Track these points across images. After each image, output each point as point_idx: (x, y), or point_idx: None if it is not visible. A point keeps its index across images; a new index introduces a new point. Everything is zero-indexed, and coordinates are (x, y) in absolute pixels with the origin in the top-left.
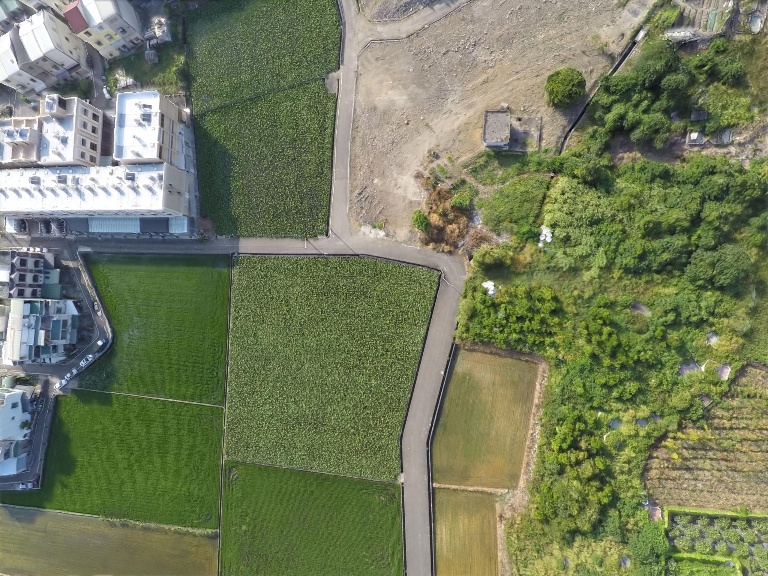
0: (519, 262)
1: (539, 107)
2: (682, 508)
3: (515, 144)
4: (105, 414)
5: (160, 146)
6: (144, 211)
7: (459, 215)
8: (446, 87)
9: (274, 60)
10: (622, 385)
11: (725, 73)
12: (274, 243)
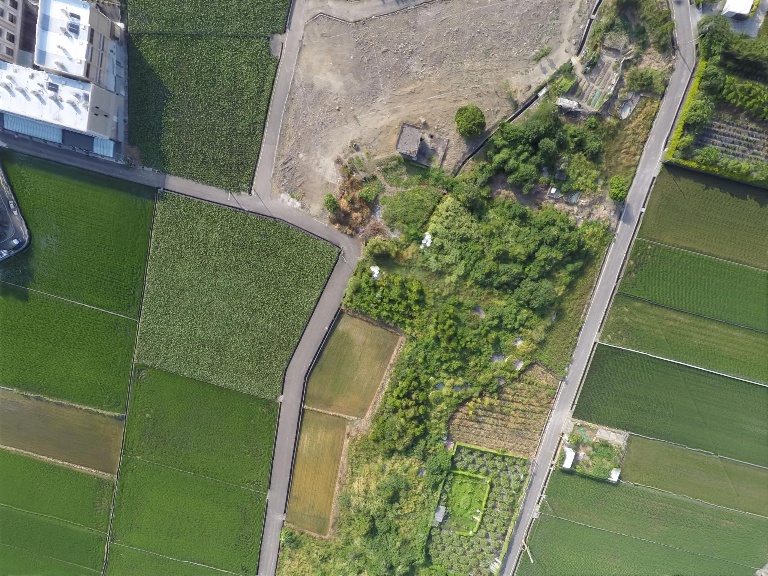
0: (402, 257)
1: (449, 130)
2: (467, 445)
3: (422, 157)
4: (20, 306)
5: (88, 64)
6: (67, 128)
7: (365, 206)
8: (378, 85)
9: None
10: (450, 362)
11: (588, 147)
12: (199, 188)
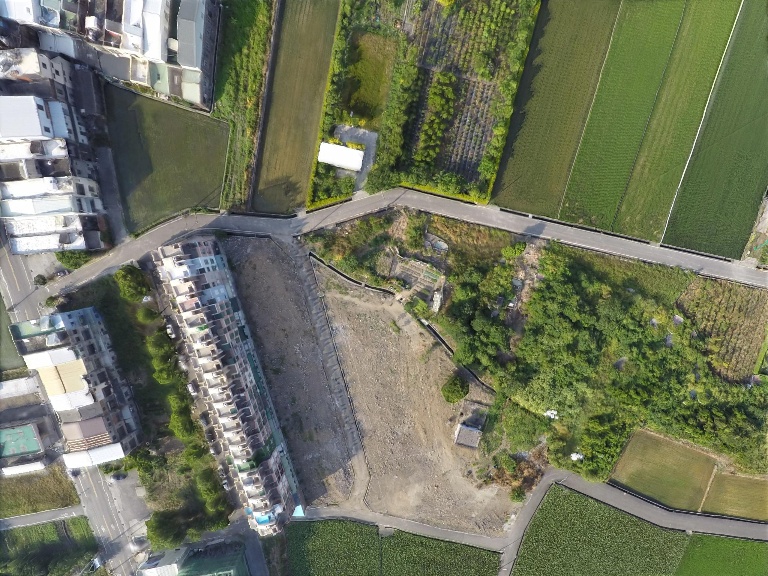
0: (566, 435)
1: None
2: (758, 364)
3: (479, 421)
4: None
5: None
6: None
7: (519, 466)
8: (419, 457)
9: (356, 572)
10: (671, 388)
11: (477, 282)
12: None
